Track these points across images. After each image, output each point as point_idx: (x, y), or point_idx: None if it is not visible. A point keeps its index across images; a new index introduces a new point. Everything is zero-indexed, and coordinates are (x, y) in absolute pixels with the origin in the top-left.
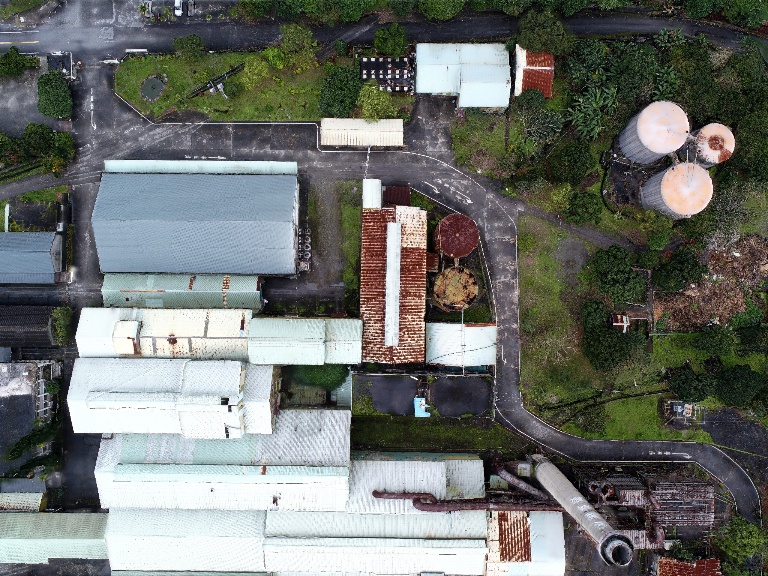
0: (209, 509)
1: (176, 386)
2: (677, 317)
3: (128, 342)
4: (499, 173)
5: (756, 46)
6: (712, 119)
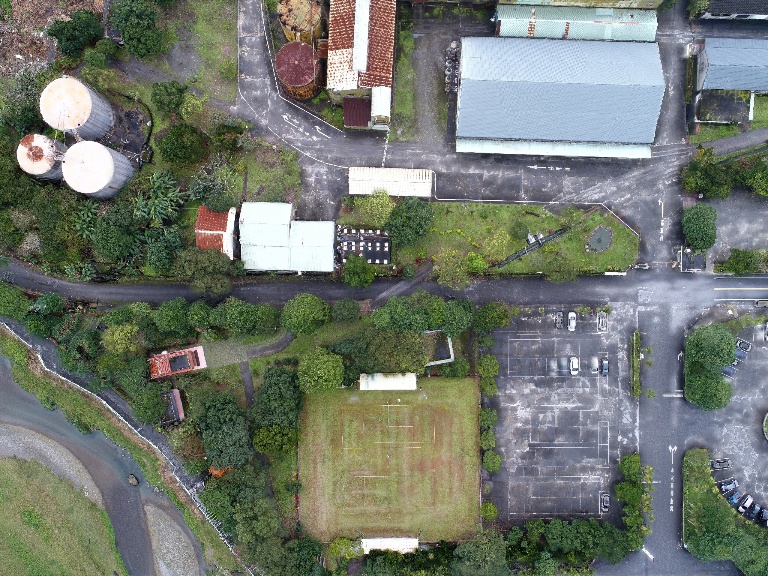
0: None
1: None
2: None
3: None
4: (254, 141)
5: None
6: (40, 185)
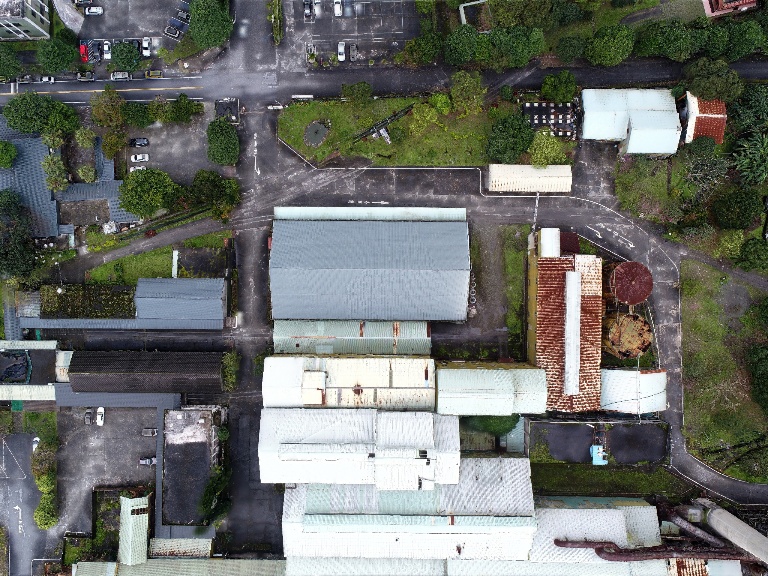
0: None
1: (365, 437)
2: None
3: (317, 393)
4: (664, 218)
5: None
6: None
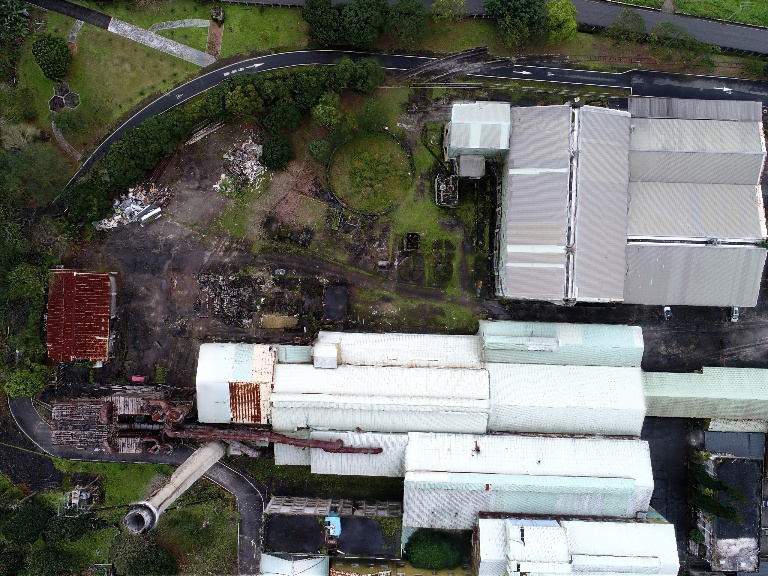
0: (543, 428)
1: (572, 573)
2: None
3: None
4: None
5: None
6: None
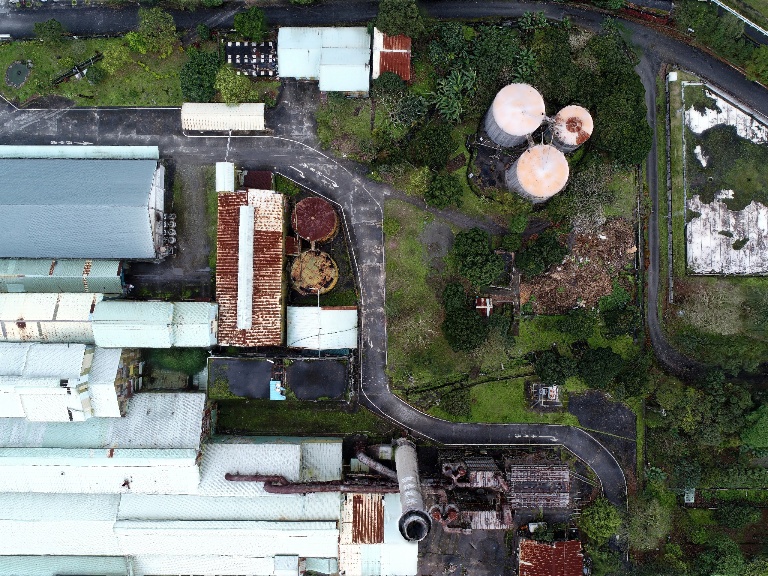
0: (66, 493)
1: (22, 369)
2: (543, 300)
3: None
4: (363, 157)
5: (615, 28)
6: (573, 102)
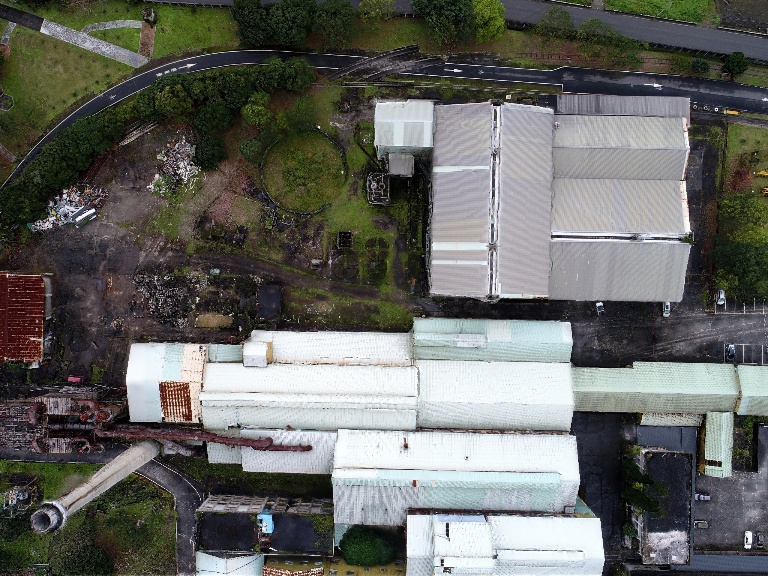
0: (474, 424)
1: (499, 568)
2: None
3: None
4: None
5: None
6: None
